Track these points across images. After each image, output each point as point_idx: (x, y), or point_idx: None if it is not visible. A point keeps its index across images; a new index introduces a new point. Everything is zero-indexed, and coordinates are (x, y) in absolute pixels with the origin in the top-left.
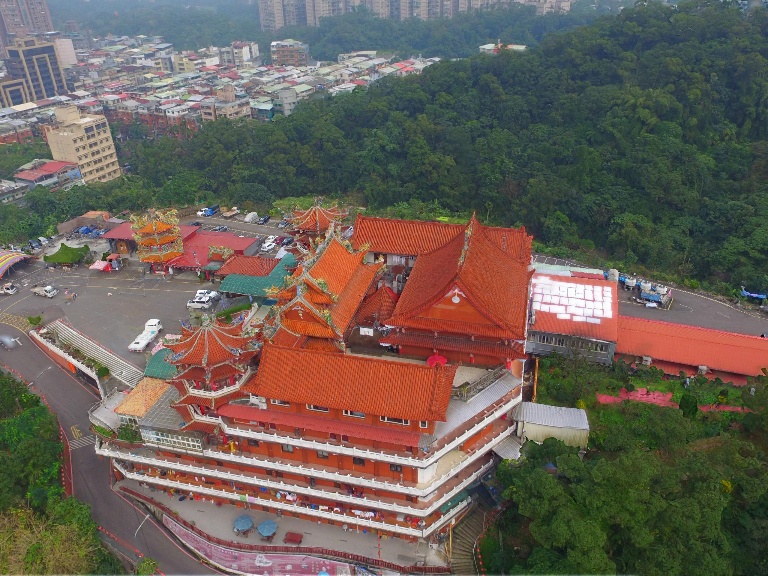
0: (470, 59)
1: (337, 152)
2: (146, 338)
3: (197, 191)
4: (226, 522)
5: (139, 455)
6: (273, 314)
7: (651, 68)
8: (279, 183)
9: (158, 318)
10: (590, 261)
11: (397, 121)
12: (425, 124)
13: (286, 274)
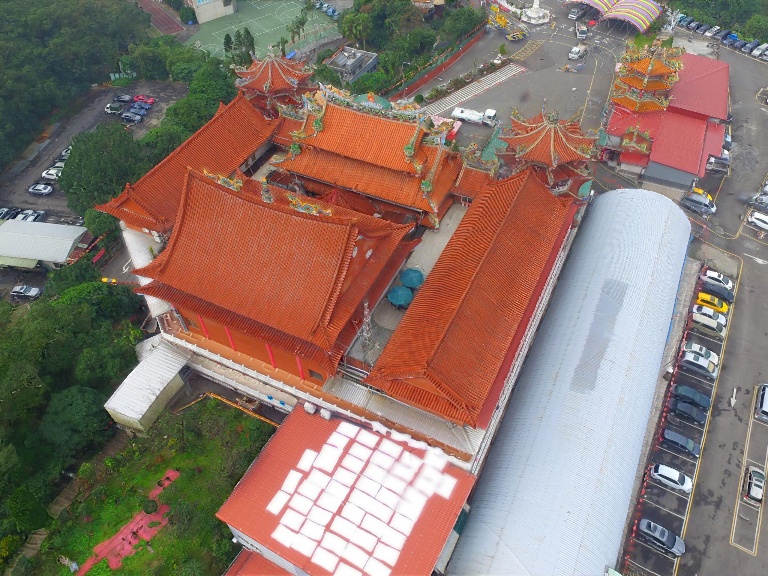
0: None
1: None
2: (471, 116)
3: None
4: None
5: None
6: None
7: None
8: None
9: None
10: None
11: None
12: None
13: None
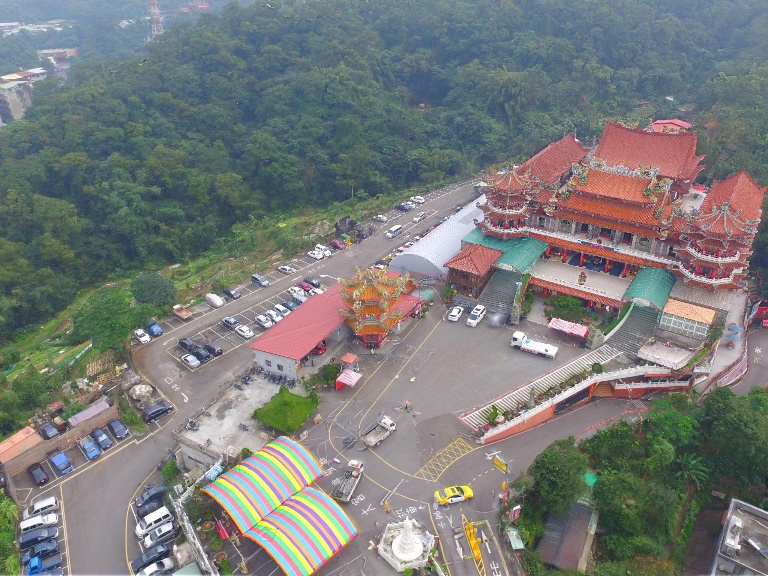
0: (93, 86)
1: (82, 226)
2: (537, 346)
3: None
4: (722, 353)
5: (716, 346)
6: (659, 214)
7: (325, 51)
8: (46, 297)
9: (488, 345)
10: (431, 188)
11: (123, 165)
12: (177, 152)
13: (506, 243)
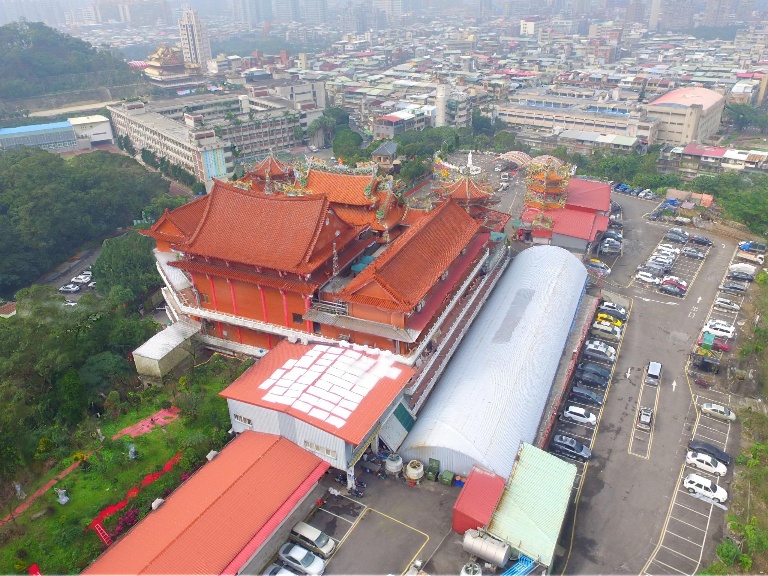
0: None
1: None
2: None
3: (763, 219)
4: None
5: None
6: None
7: None
8: None
9: None
10: None
11: None
12: None
13: None
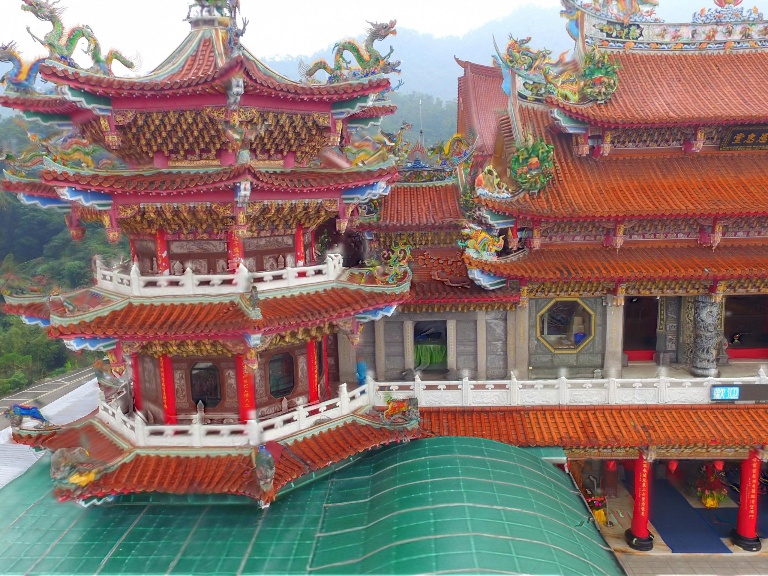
0: None
1: None
2: None
3: None
4: None
5: None
6: None
7: None
8: None
9: None
10: None
11: None
12: None
13: (283, 526)
